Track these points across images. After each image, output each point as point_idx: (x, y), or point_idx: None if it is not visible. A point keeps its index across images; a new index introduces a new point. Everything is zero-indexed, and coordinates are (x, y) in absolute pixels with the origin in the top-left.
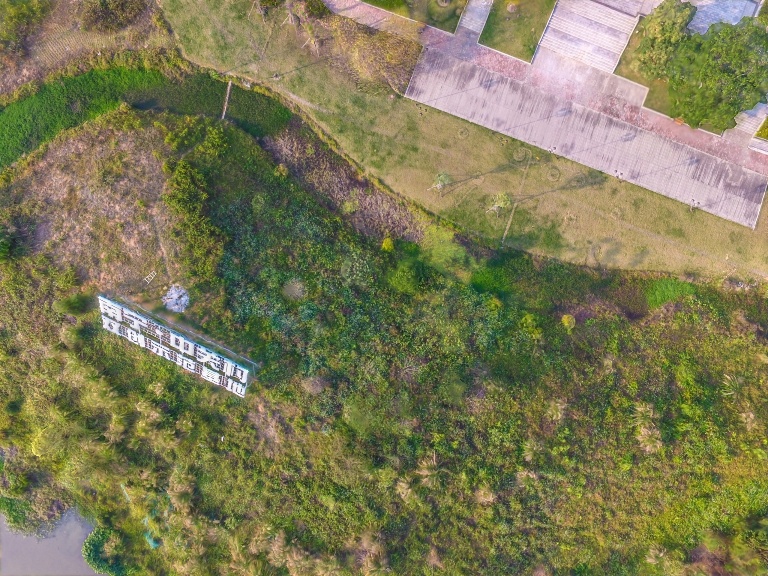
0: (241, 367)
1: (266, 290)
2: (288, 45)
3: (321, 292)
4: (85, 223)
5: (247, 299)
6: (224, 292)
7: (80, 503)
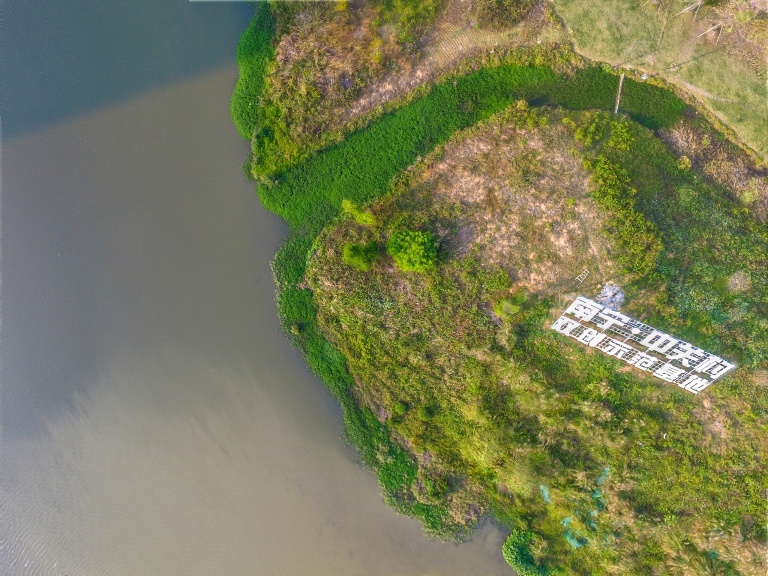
0: (728, 363)
1: (700, 284)
2: (684, 34)
3: (751, 284)
4: (511, 224)
5: (685, 294)
6: (664, 288)
7: (496, 506)
